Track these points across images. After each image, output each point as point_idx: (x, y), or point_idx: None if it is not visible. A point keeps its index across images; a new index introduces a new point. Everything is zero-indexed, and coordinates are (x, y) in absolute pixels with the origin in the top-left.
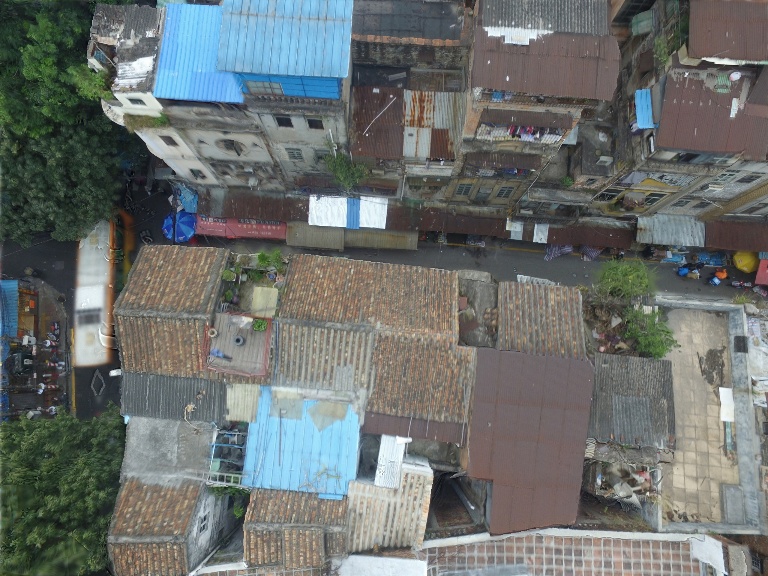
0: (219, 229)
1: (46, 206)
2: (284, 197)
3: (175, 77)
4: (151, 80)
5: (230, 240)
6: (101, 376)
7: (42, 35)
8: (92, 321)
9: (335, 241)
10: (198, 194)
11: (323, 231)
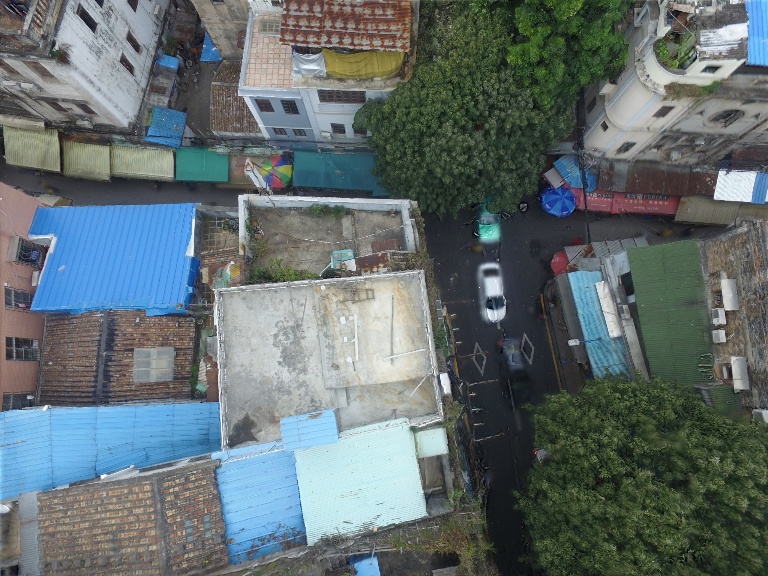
0: (603, 204)
1: (509, 178)
2: (691, 171)
3: (766, 44)
4: (746, 47)
5: (598, 216)
6: (480, 348)
7: (616, 3)
8: (463, 295)
9: (727, 216)
10: (600, 168)
11: (716, 206)
